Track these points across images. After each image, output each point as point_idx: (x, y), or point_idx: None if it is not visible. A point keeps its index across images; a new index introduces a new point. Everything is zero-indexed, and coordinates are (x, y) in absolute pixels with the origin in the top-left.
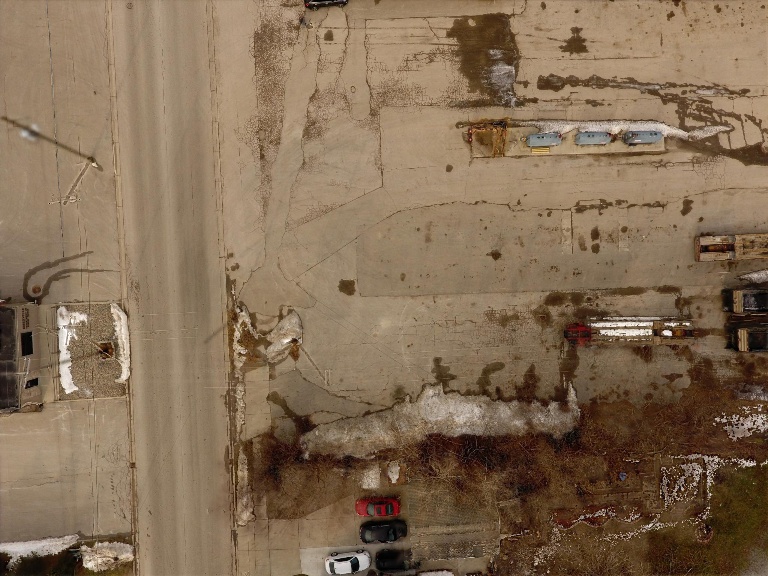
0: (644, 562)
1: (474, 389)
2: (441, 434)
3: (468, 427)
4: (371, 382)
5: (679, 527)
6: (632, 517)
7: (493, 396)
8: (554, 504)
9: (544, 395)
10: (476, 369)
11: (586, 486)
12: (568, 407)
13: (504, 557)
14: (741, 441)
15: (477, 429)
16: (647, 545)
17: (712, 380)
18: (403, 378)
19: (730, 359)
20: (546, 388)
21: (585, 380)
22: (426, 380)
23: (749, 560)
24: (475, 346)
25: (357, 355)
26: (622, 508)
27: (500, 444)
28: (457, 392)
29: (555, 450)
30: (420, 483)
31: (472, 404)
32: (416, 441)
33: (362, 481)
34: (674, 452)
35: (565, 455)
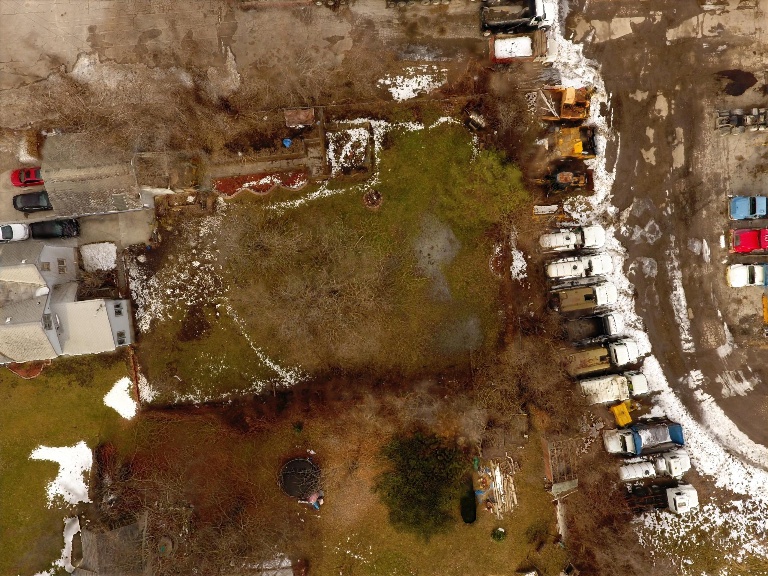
0: (313, 230)
1: (131, 57)
2: (98, 103)
3: (123, 93)
4: (25, 53)
5: (348, 194)
6: (298, 184)
7: (150, 64)
8: (217, 172)
9: (203, 61)
10: (132, 37)
11: (250, 154)
12: (227, 72)
13: (168, 228)
14: (405, 101)
15: (132, 95)
16: (315, 213)
17: (374, 41)
18: (58, 48)
19: (392, 19)
20: (204, 54)
21: (244, 45)
22: (81, 49)
23: (422, 227)
24: (130, 13)
25: (10, 26)
26: (287, 174)
27: (155, 108)
28: (113, 60)
29: (212, 114)
30: (59, 135)
31: (127, 70)
32: (72, 110)
33: (19, 153)
34: (339, 116)
35: (225, 120)
